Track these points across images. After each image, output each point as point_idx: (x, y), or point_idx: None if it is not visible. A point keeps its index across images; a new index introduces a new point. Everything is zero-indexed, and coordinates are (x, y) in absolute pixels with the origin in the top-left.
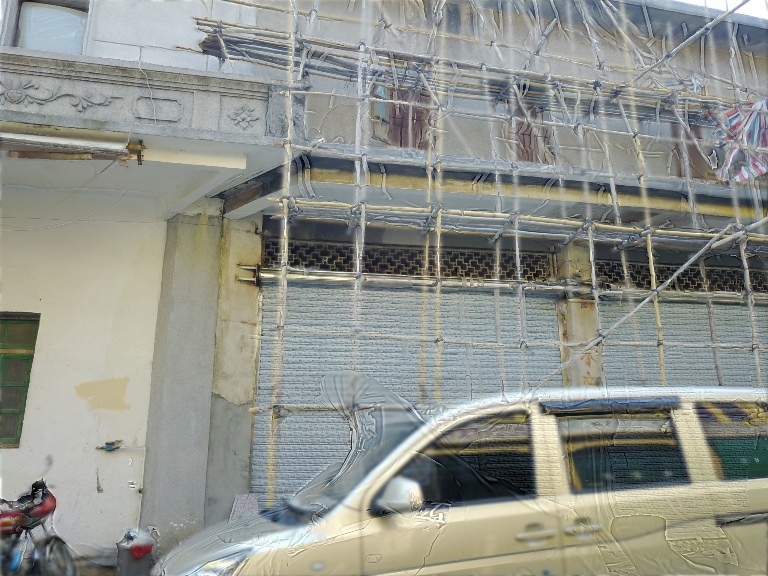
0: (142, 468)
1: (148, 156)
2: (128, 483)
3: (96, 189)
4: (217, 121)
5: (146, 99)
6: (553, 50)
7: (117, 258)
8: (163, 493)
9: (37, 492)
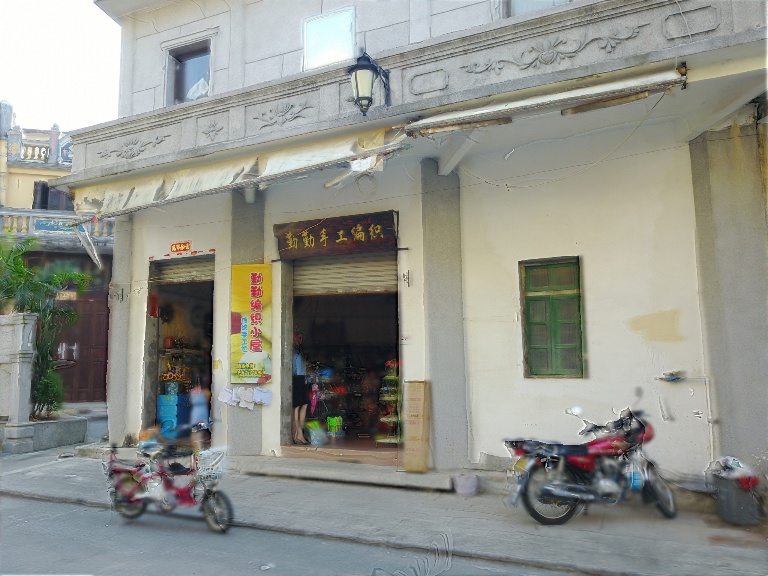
0: (706, 398)
1: (691, 77)
2: (693, 413)
3: (611, 127)
4: (765, 13)
5: (676, 16)
6: None
7: (642, 191)
8: (738, 424)
9: (624, 419)
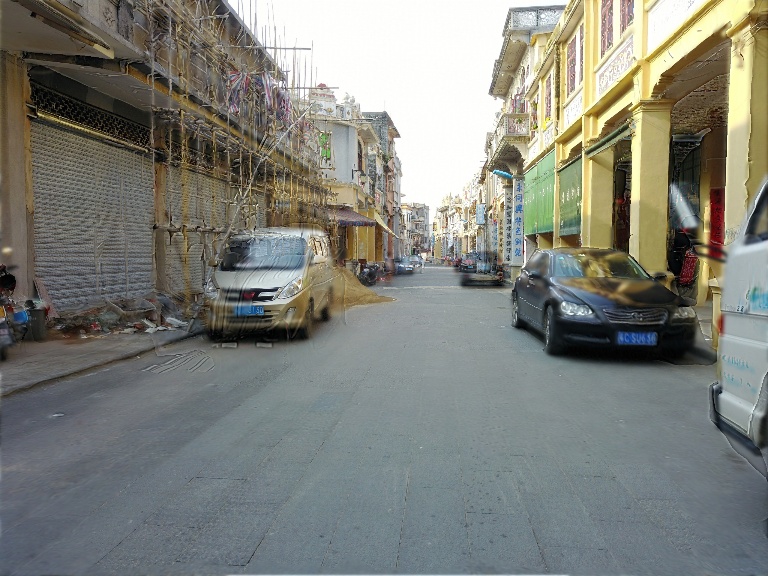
0: None
1: None
2: None
3: None
4: None
5: None
6: None
7: None
8: None
9: None
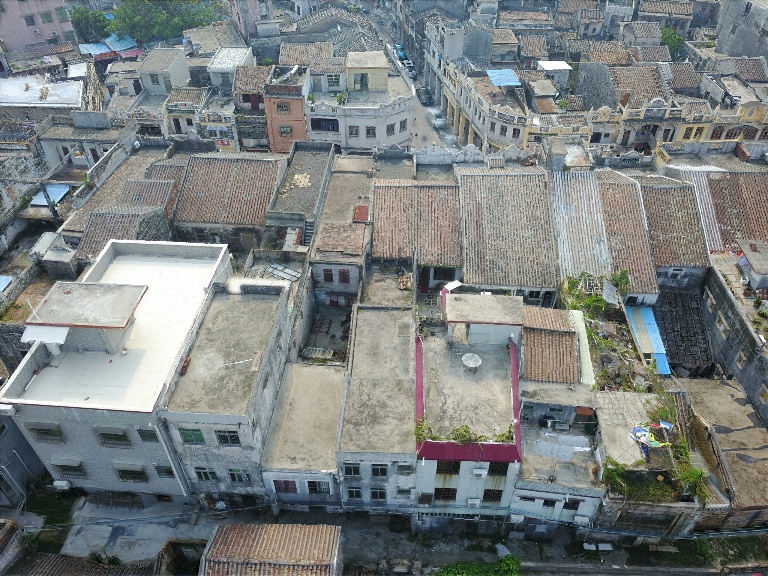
0: None
1: None
2: None
3: None
4: None
5: None
6: (5, 109)
7: None
8: None
9: None
